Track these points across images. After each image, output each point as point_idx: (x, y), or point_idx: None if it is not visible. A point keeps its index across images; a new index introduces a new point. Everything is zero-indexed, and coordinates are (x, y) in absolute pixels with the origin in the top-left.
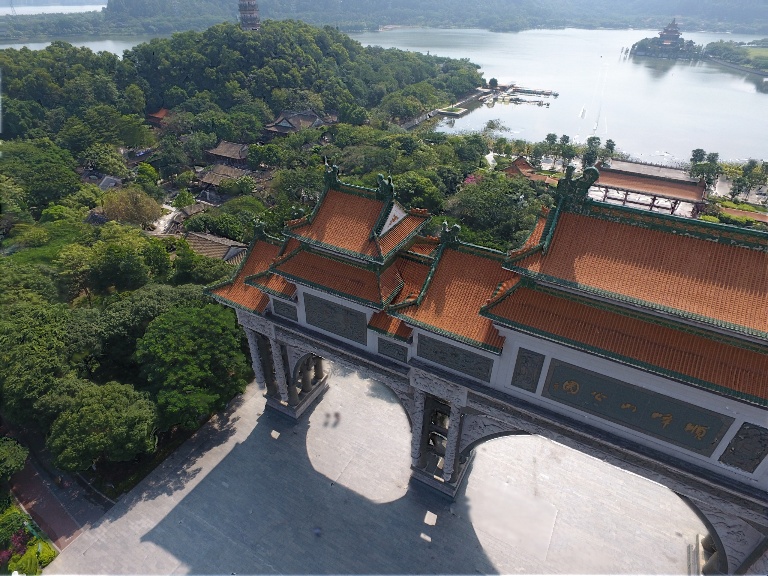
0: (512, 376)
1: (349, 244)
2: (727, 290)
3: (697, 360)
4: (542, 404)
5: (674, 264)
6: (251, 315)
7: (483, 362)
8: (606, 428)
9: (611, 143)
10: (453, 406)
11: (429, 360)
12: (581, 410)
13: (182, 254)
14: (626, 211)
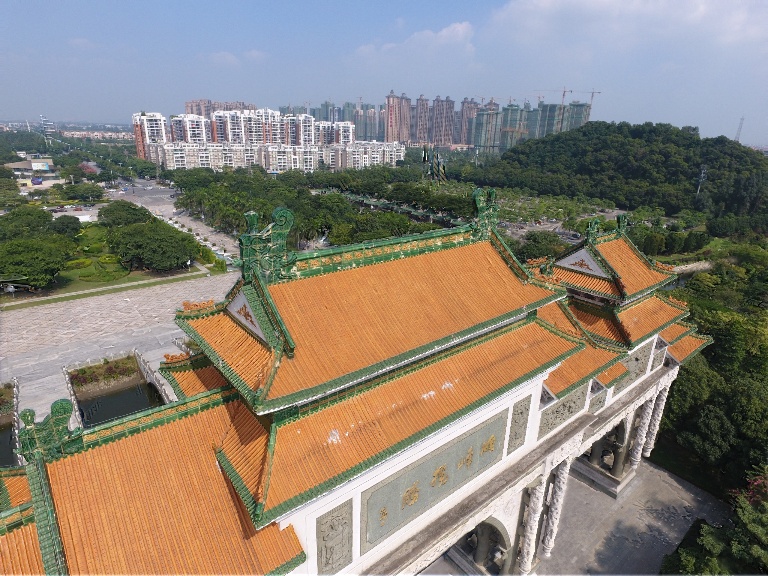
0: None
1: None
2: None
3: None
4: None
5: None
6: None
7: None
8: None
9: None
10: None
11: None
12: None
13: (759, 359)
14: None
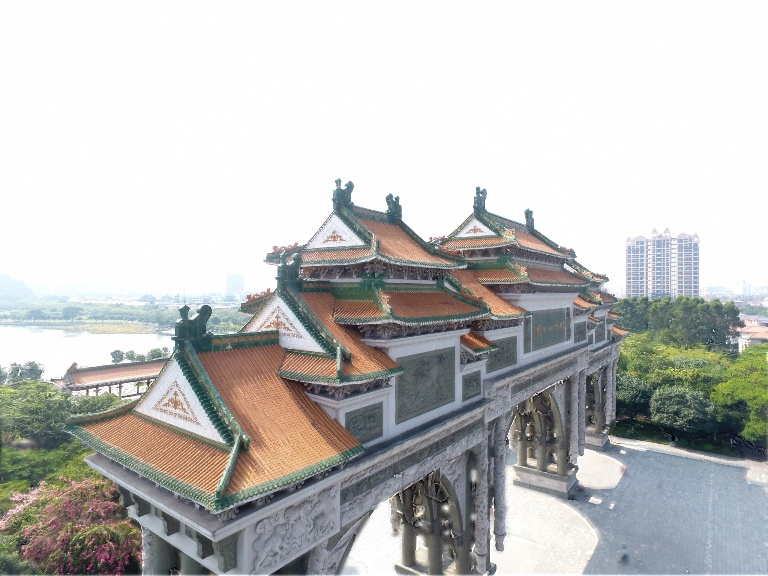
0: (523, 344)
1: (427, 259)
2: None
3: None
4: (533, 359)
5: None
6: (297, 507)
7: None
8: (548, 354)
9: (18, 366)
10: (504, 419)
11: (492, 372)
12: (542, 348)
13: None
14: None
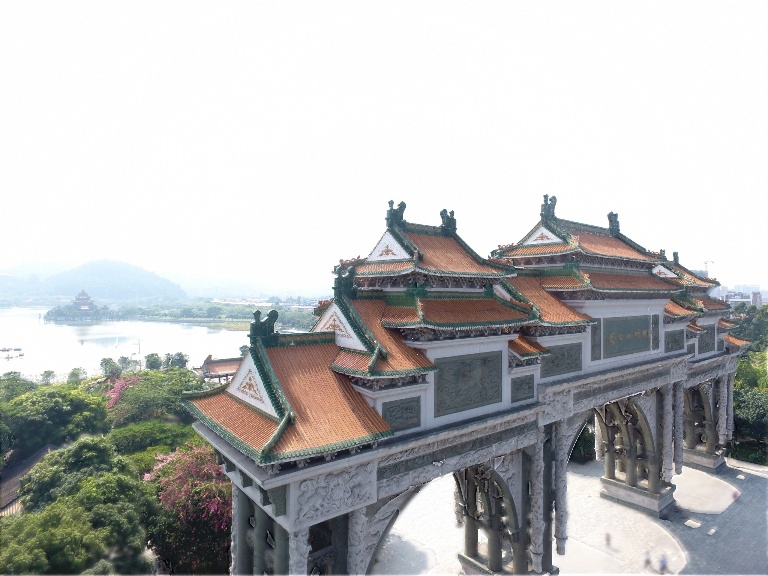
0: (591, 351)
1: (473, 269)
2: (618, 249)
3: (639, 283)
4: (604, 367)
5: (599, 243)
6: (336, 475)
7: (577, 350)
8: (626, 362)
9: (170, 356)
10: (565, 424)
11: (548, 377)
12: (617, 356)
13: None
14: (567, 222)
